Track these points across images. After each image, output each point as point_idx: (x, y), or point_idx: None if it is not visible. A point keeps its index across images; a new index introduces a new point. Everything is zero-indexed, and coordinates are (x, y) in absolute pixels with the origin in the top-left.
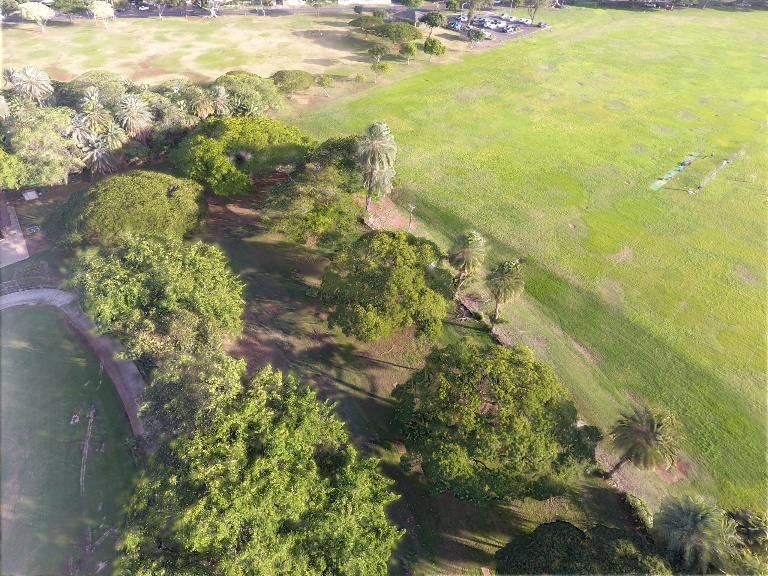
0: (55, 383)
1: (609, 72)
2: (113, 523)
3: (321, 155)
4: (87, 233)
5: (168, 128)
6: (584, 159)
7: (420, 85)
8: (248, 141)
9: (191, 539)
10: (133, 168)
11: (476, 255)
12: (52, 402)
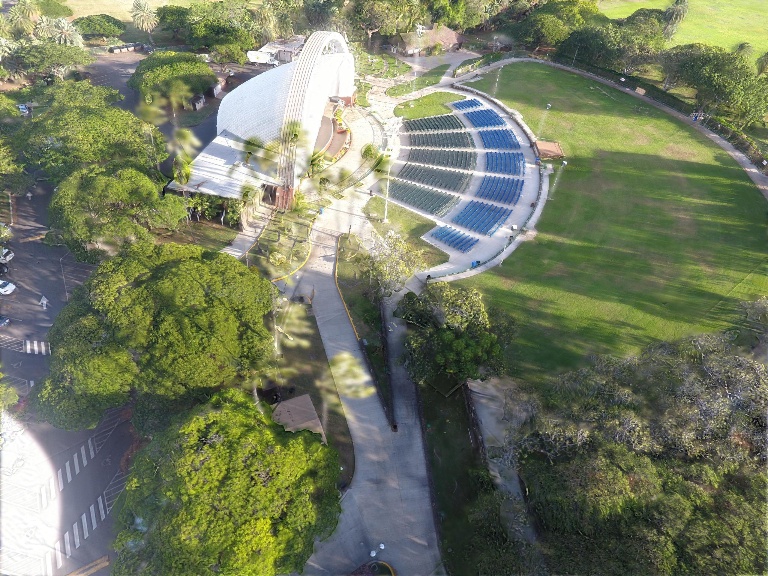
0: (570, 80)
1: (759, 14)
2: (641, 106)
3: (645, 13)
4: (534, 38)
5: (524, 6)
6: (764, 49)
7: (629, 11)
8: (589, 9)
9: (733, 62)
10: (491, 31)
11: (747, 54)
12: (576, 84)
